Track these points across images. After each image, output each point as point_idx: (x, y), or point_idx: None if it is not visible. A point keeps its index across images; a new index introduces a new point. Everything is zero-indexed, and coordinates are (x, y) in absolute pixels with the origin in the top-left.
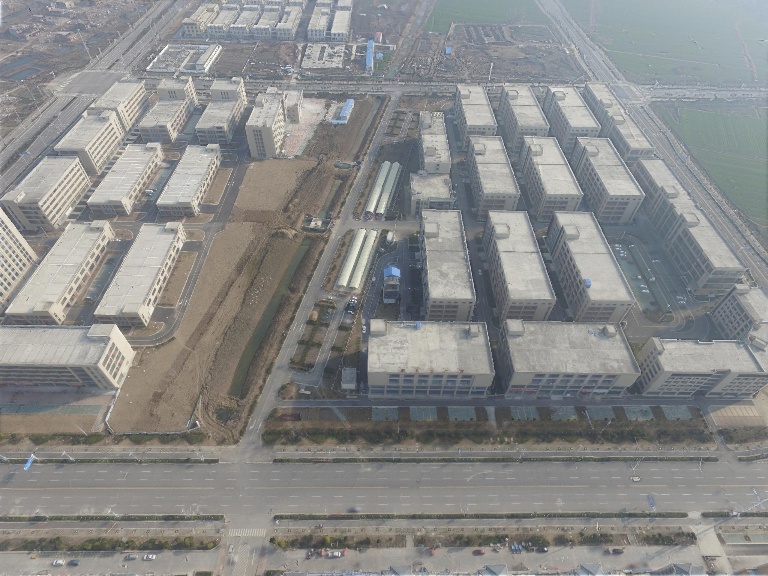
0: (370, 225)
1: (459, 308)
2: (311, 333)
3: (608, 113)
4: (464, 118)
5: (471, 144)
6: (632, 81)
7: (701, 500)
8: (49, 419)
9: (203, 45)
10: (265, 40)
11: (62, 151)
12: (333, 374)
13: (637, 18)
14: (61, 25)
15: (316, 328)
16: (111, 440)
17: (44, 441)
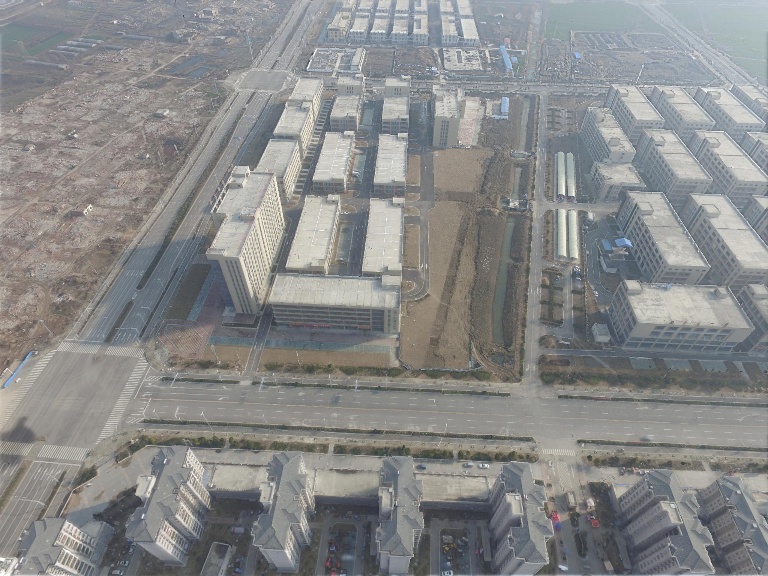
0: (565, 206)
1: (690, 276)
2: (549, 295)
3: (767, 111)
4: (629, 114)
5: (646, 136)
6: (766, 85)
7: None
8: (350, 355)
9: (349, 49)
10: (402, 45)
11: (280, 136)
12: (583, 329)
13: (749, 27)
14: (214, 30)
15: (553, 291)
16: (410, 374)
17: (354, 372)
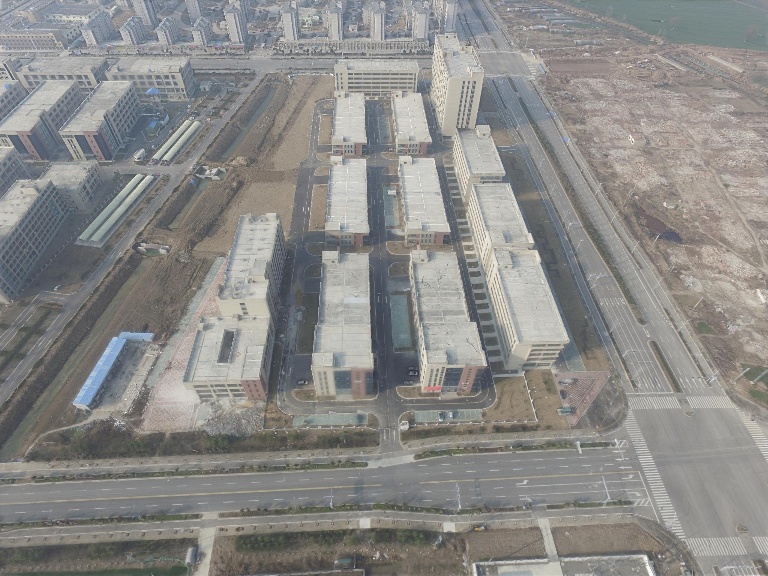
0: (155, 170)
1: None
2: (226, 104)
3: None
4: None
5: None
6: None
7: None
8: None
9: None
10: None
11: None
12: None
13: None
14: None
15: (222, 105)
16: None
17: None
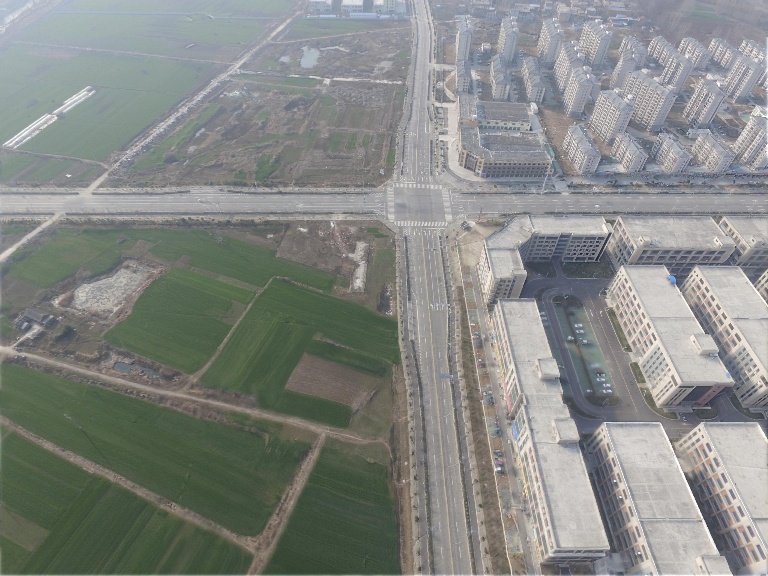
0: None
1: None
2: None
3: None
4: None
5: None
6: None
7: (560, 198)
8: None
9: None
10: None
11: None
12: None
13: None
14: None
15: None
16: None
17: None
